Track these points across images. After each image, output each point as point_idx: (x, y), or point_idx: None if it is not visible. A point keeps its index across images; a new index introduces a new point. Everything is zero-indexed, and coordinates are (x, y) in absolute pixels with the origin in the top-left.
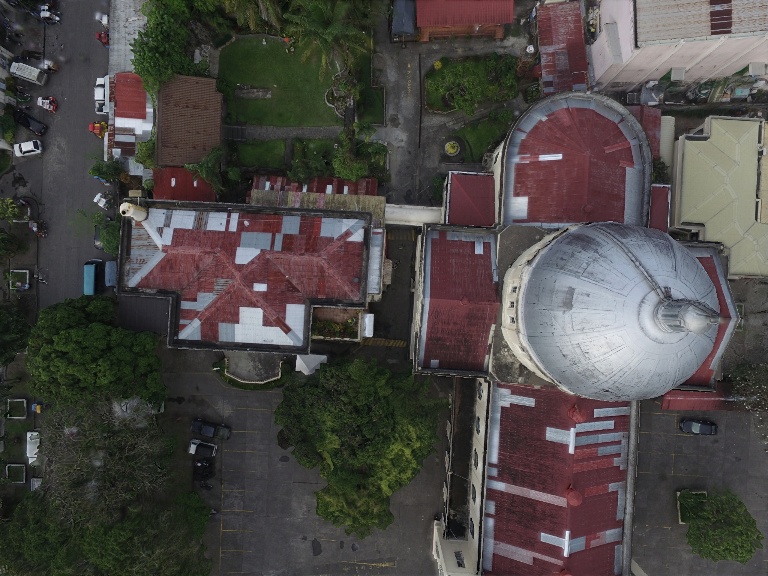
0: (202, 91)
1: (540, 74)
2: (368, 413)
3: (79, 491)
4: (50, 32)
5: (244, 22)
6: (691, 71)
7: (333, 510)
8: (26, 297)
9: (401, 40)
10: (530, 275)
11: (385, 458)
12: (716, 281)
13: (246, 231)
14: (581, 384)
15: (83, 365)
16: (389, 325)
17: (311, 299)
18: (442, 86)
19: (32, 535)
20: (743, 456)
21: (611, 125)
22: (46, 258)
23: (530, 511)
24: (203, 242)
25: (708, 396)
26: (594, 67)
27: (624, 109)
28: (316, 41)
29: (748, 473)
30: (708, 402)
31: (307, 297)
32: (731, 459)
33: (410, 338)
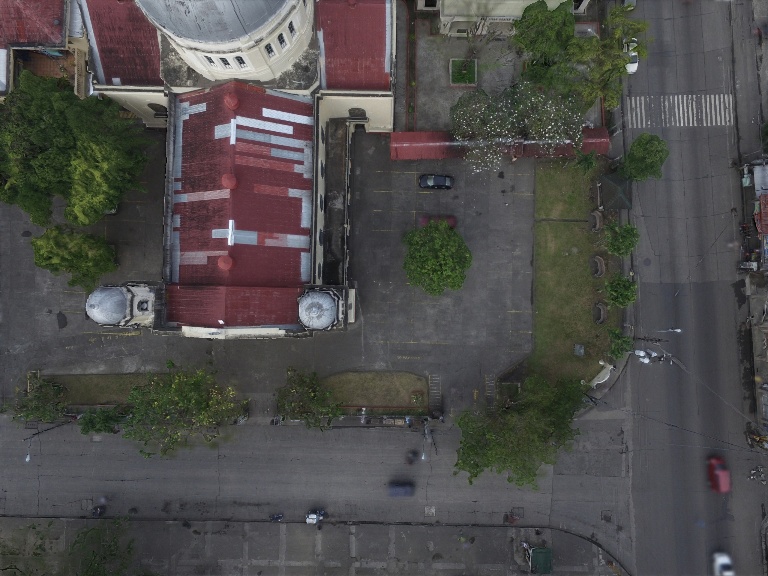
0: None
1: None
2: None
3: None
4: None
5: None
6: None
7: (43, 252)
8: None
9: None
10: None
11: (77, 184)
12: None
13: None
14: (155, 1)
15: None
16: None
17: (13, 44)
18: None
19: None
20: (483, 210)
21: None
22: None
23: (204, 212)
24: None
25: (433, 141)
26: None
27: None
28: None
29: (489, 227)
30: (435, 148)
31: (9, 42)
32: (472, 214)
33: None
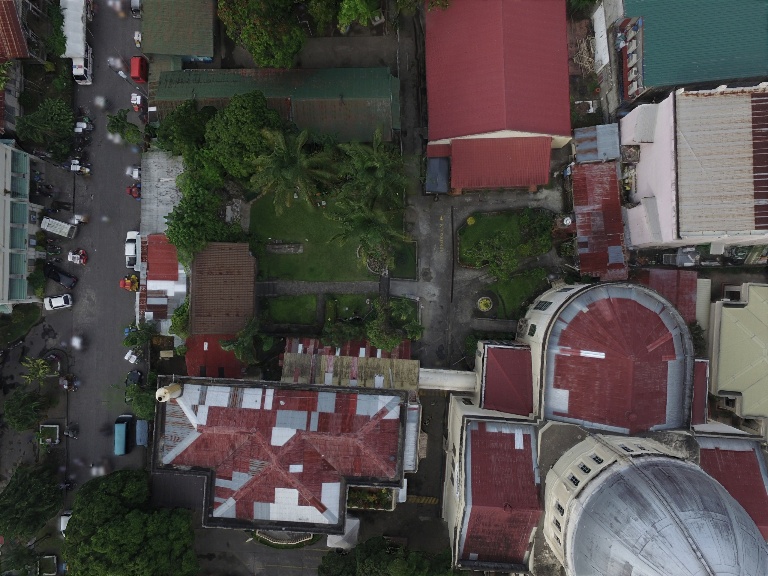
0: (235, 257)
1: (574, 232)
2: None
3: None
4: (80, 182)
5: None
6: (730, 243)
7: None
8: (56, 451)
9: (433, 193)
10: (580, 516)
11: None
12: (760, 481)
13: (281, 409)
14: None
15: (121, 566)
16: (421, 482)
17: (346, 477)
18: (478, 257)
19: None
20: None
21: (653, 317)
22: (76, 411)
23: None
24: (238, 421)
25: None
26: (630, 232)
27: (666, 302)
28: None
29: None
30: None
31: (342, 475)
32: None
33: (442, 497)
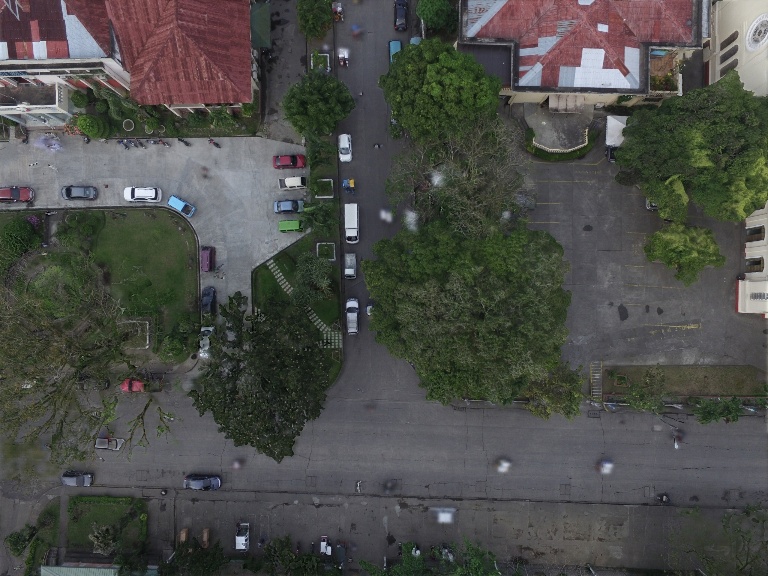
0: None
1: None
2: (742, 122)
3: (484, 194)
4: None
5: None
6: None
7: (675, 246)
8: None
9: None
10: None
11: (741, 180)
12: None
13: None
14: None
15: None
16: None
17: (645, 43)
18: None
19: (424, 250)
20: None
21: None
22: (343, 43)
23: None
24: None
25: None
26: None
27: None
28: None
29: None
30: None
31: (641, 41)
32: None
33: None
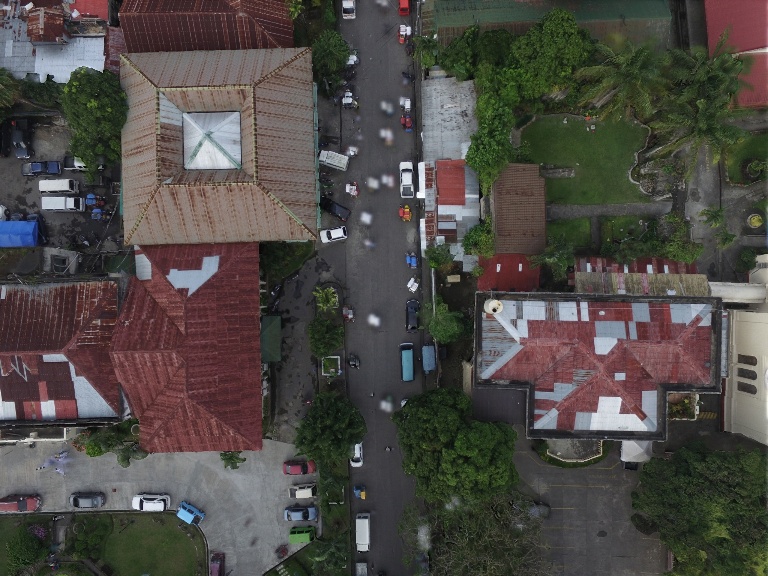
0: (528, 177)
1: None
2: (763, 505)
3: None
4: (346, 116)
5: (550, 103)
6: None
7: None
8: (336, 382)
9: None
10: None
11: None
12: None
13: (599, 320)
14: None
15: (487, 469)
16: None
17: (662, 385)
18: None
19: None
20: None
21: None
22: (354, 342)
23: None
24: (560, 333)
25: None
26: None
27: None
28: (690, 137)
29: None
30: None
31: (659, 383)
32: None
33: (723, 410)
